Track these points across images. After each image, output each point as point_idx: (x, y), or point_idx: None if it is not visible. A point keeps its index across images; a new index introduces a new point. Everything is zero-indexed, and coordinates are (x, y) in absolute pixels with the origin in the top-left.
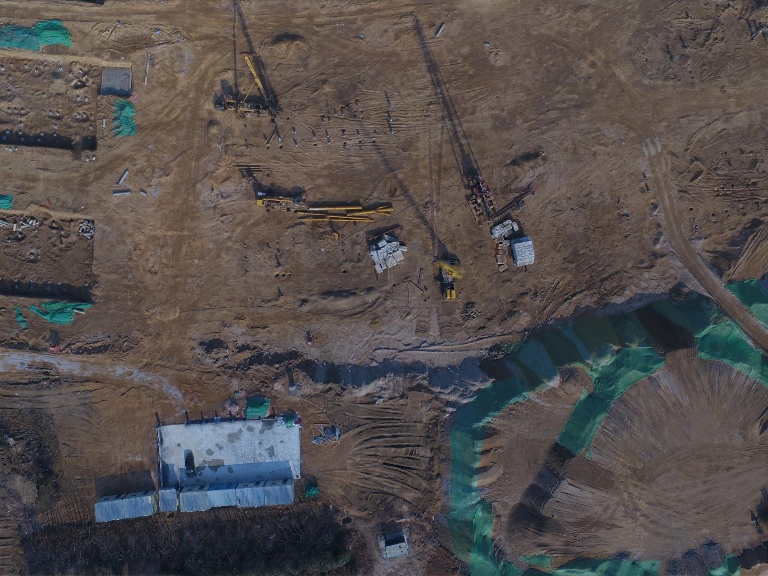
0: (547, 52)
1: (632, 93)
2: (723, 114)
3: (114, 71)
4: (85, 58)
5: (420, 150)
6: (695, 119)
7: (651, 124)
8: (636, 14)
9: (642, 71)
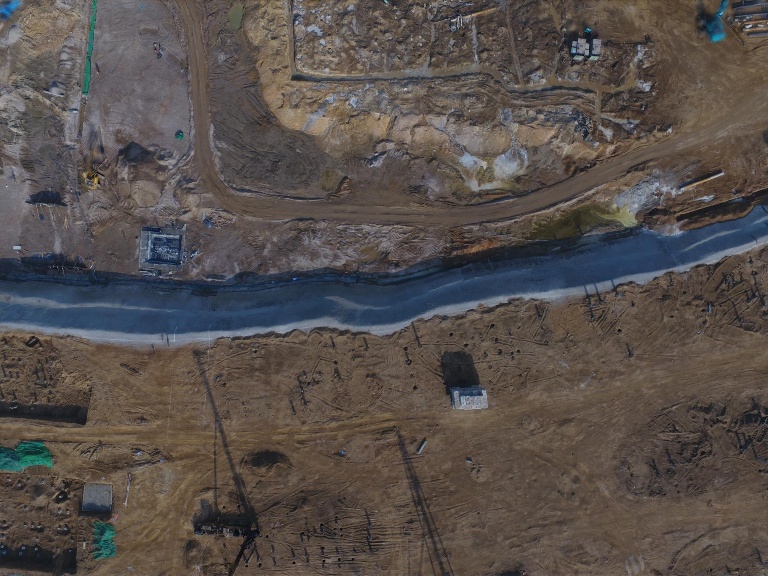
0: (530, 467)
1: (616, 509)
2: (709, 530)
3: (95, 487)
4: (67, 477)
5: (399, 568)
6: (680, 535)
7: (635, 541)
8: (622, 427)
9: (627, 486)
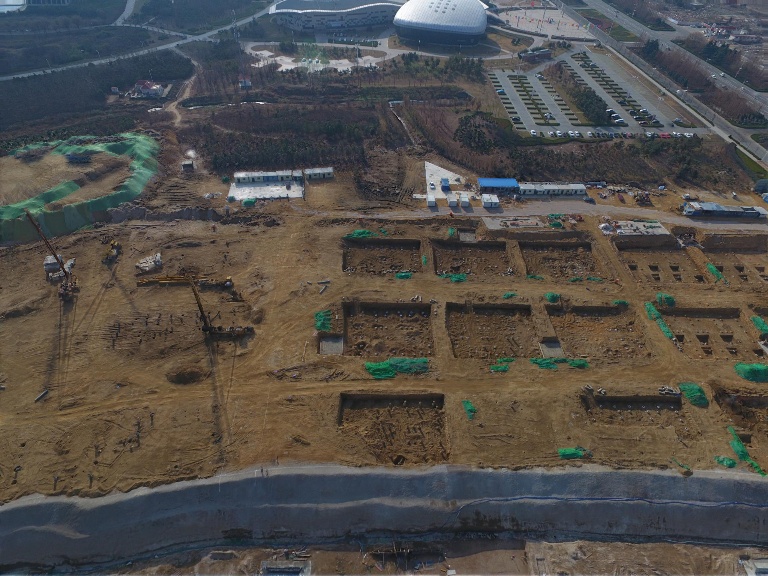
0: None
1: None
2: None
3: (334, 353)
4: None
5: (102, 316)
6: None
7: None
8: None
9: None
